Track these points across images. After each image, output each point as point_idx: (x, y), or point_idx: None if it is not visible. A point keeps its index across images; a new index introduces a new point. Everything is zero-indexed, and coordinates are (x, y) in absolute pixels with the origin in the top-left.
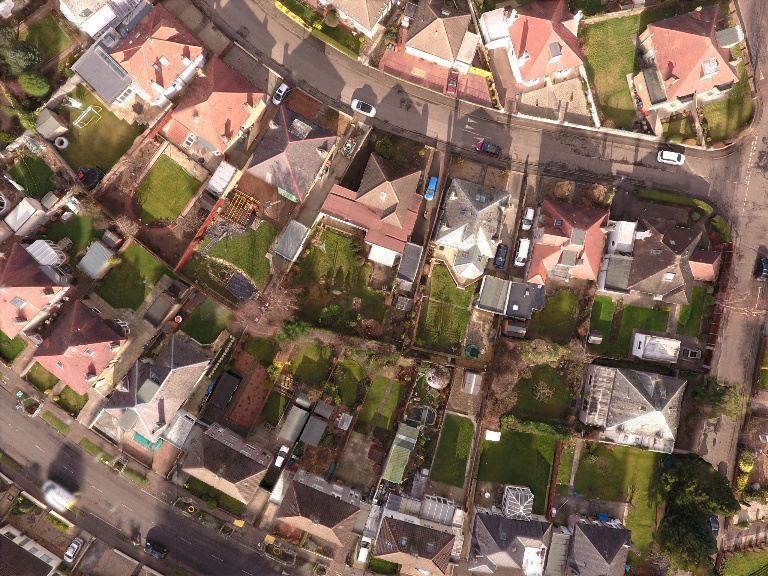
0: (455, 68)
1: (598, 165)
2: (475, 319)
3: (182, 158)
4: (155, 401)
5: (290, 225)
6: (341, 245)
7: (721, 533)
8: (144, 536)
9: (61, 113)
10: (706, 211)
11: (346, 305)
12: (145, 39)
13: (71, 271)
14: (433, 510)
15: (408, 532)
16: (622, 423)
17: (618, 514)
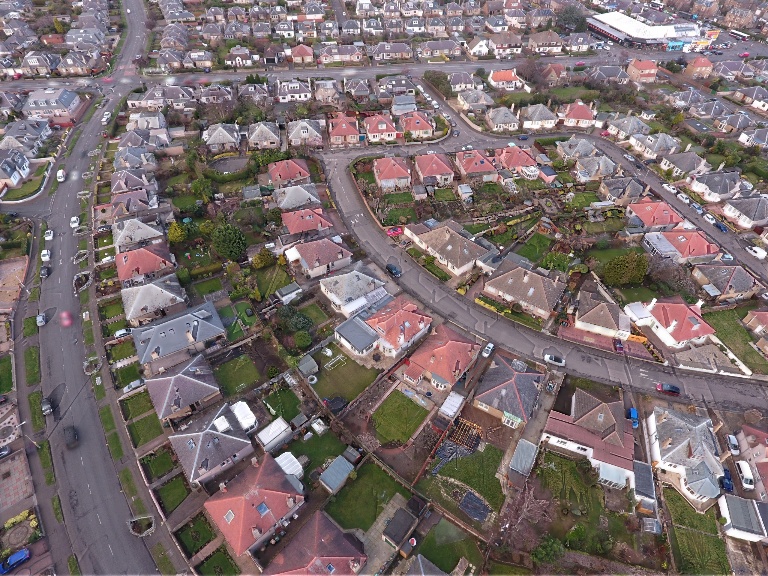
0: (617, 336)
1: (767, 403)
2: (732, 548)
3: None
4: None
5: (519, 443)
6: (566, 467)
7: None
8: None
9: None
10: None
11: (588, 529)
12: (398, 310)
13: (304, 488)
14: None
15: None
16: None
17: None
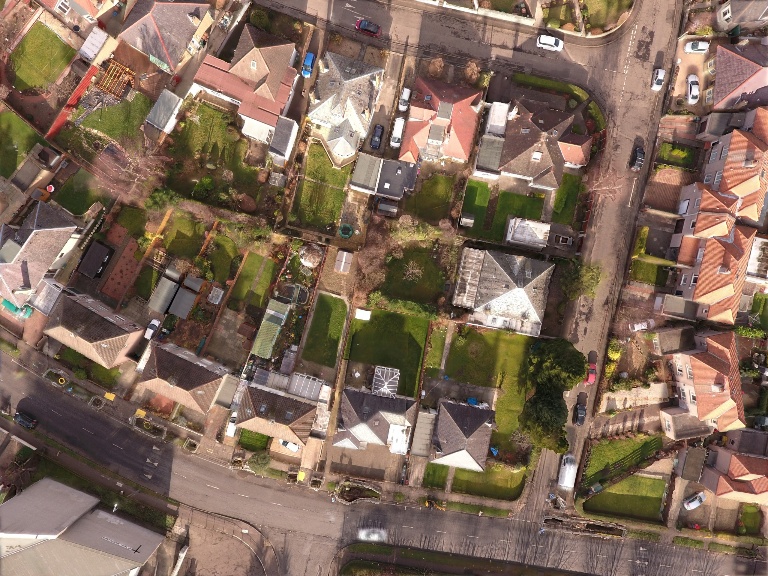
0: None
1: (478, 49)
2: (350, 200)
3: (57, 25)
4: (17, 262)
5: (162, 94)
6: (217, 120)
7: (589, 421)
8: (14, 406)
9: None
10: (582, 97)
11: (221, 181)
12: None
13: None
14: (300, 385)
15: (268, 400)
16: (488, 303)
17: (487, 399)
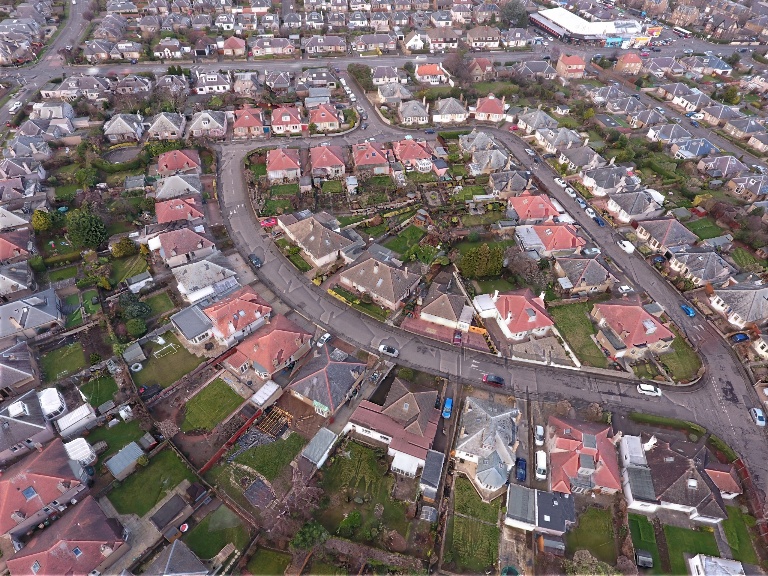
0: (458, 328)
1: (589, 395)
2: (506, 537)
3: (233, 381)
4: None
5: (319, 432)
6: (365, 455)
7: None
8: None
9: (146, 348)
10: (700, 431)
11: (367, 517)
12: (234, 299)
13: (93, 473)
14: None
15: None
16: None
17: None
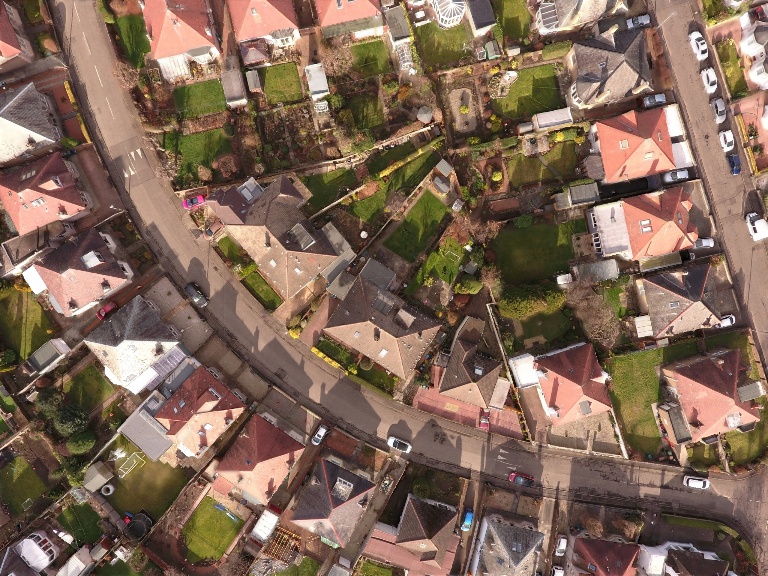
0: None
1: (626, 489)
2: None
3: (225, 499)
4: None
5: (333, 569)
6: None
7: None
8: None
9: (106, 460)
10: (732, 535)
11: None
12: (190, 415)
13: None
14: None
15: None
16: None
17: None
